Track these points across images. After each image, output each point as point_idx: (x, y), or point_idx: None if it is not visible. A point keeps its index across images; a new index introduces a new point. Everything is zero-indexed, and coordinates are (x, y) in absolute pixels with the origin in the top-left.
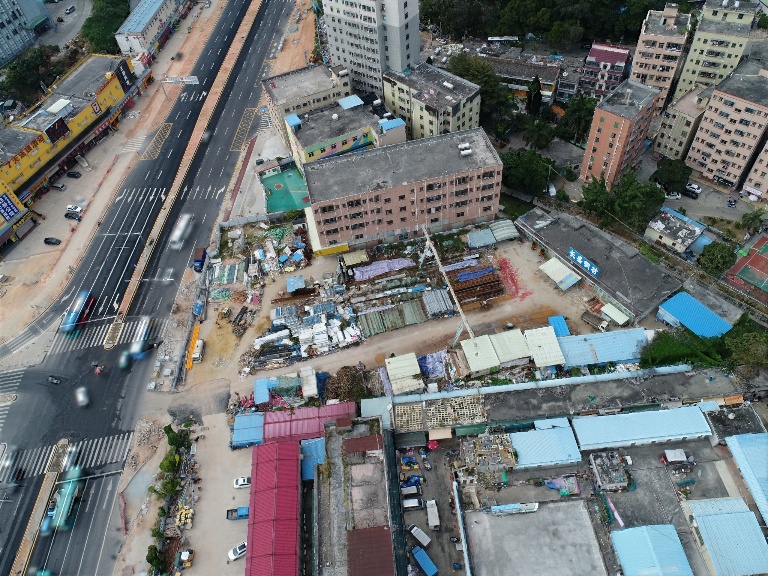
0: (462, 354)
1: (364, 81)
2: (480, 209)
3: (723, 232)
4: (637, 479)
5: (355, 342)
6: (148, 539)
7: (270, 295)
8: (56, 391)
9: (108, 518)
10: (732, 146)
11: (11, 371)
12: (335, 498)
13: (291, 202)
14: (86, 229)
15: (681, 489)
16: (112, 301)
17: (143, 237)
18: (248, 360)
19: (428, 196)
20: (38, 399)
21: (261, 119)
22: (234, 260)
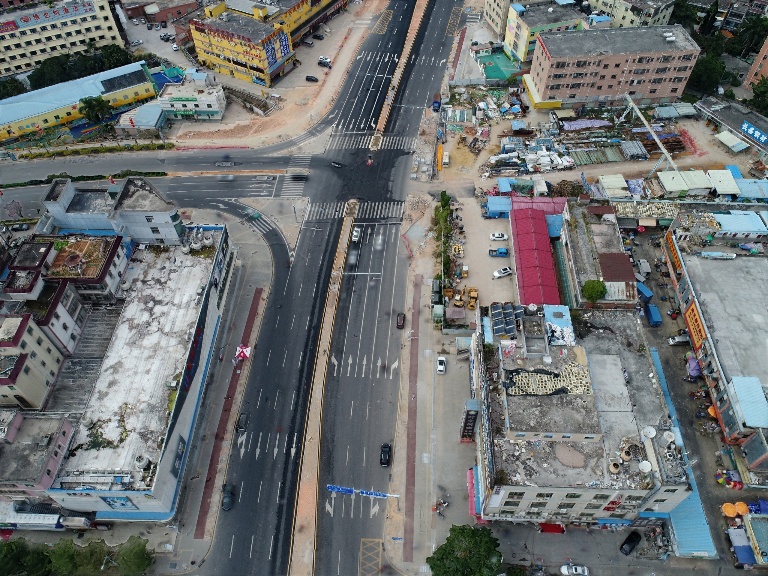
0: (656, 182)
1: None
2: (669, 89)
3: None
4: None
5: (570, 166)
6: (429, 262)
7: (496, 132)
8: (339, 171)
9: (397, 247)
10: None
11: (301, 155)
12: (582, 240)
13: (502, 75)
14: (337, 74)
15: None
16: (370, 122)
17: (386, 84)
18: (486, 169)
19: (636, 68)
20: (327, 174)
21: (468, 16)
22: (462, 107)
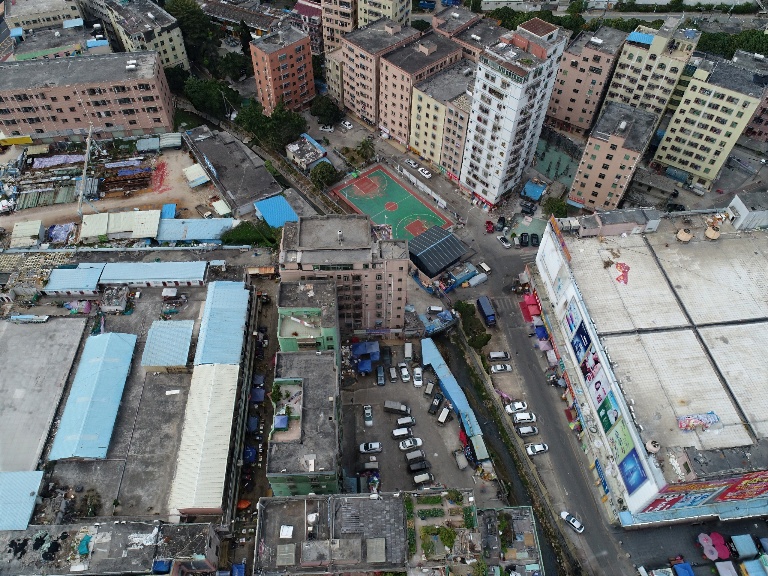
0: None
1: (97, 9)
2: (150, 120)
3: (347, 158)
4: (137, 308)
5: (5, 212)
6: None
7: None
8: None
9: None
10: (362, 88)
11: None
12: None
13: None
14: None
15: (165, 316)
16: None
17: None
18: None
19: (92, 100)
20: None
21: None
22: None
